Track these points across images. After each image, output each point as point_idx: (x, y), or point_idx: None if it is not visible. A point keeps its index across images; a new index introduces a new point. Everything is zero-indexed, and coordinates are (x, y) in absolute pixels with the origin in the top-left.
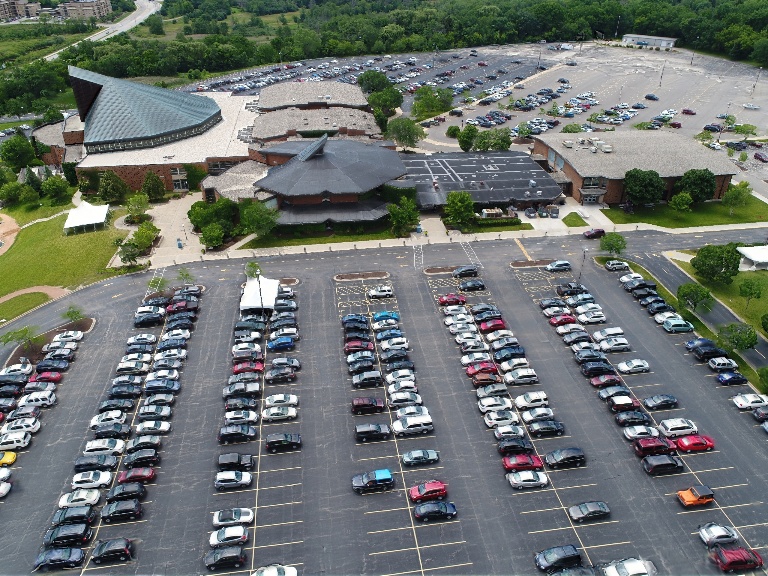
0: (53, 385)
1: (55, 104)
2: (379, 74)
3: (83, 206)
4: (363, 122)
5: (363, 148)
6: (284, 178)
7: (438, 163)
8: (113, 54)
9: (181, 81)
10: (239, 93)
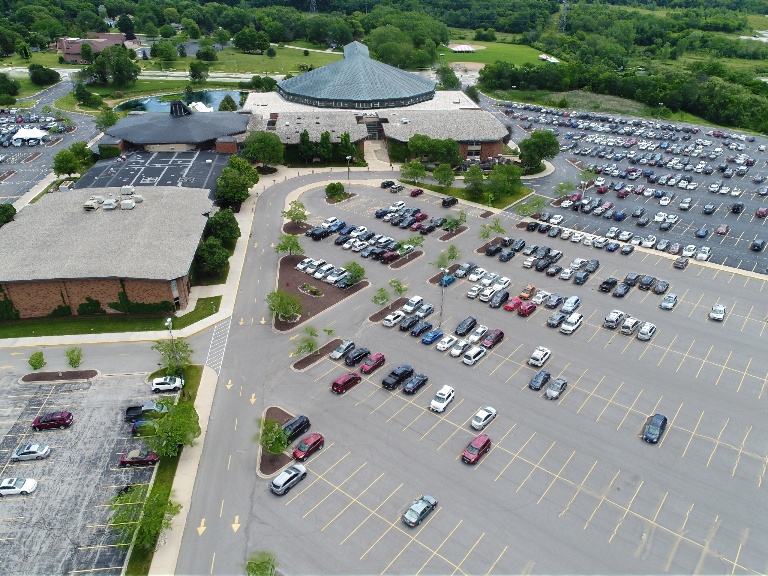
0: (12, 121)
1: (500, 92)
2: (541, 137)
3: (193, 103)
4: (311, 136)
5: (202, 129)
6: (148, 114)
7: (180, 163)
8: (660, 76)
9: (626, 112)
10: (561, 126)
